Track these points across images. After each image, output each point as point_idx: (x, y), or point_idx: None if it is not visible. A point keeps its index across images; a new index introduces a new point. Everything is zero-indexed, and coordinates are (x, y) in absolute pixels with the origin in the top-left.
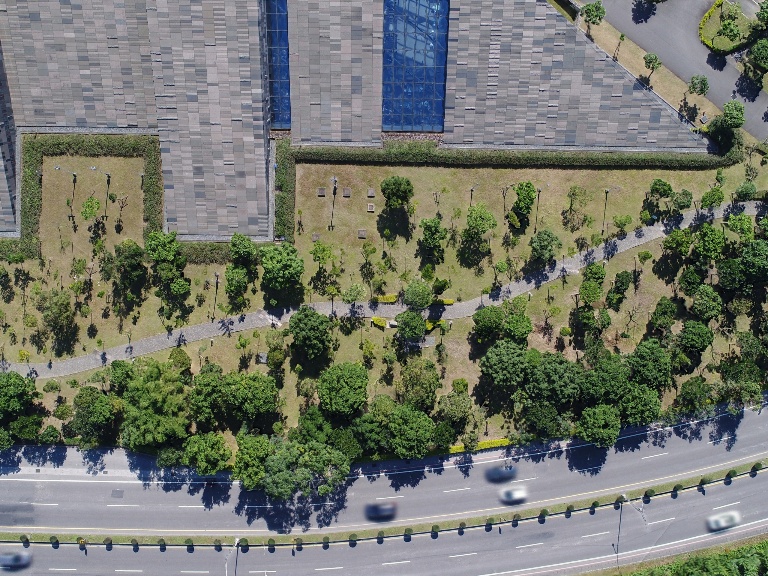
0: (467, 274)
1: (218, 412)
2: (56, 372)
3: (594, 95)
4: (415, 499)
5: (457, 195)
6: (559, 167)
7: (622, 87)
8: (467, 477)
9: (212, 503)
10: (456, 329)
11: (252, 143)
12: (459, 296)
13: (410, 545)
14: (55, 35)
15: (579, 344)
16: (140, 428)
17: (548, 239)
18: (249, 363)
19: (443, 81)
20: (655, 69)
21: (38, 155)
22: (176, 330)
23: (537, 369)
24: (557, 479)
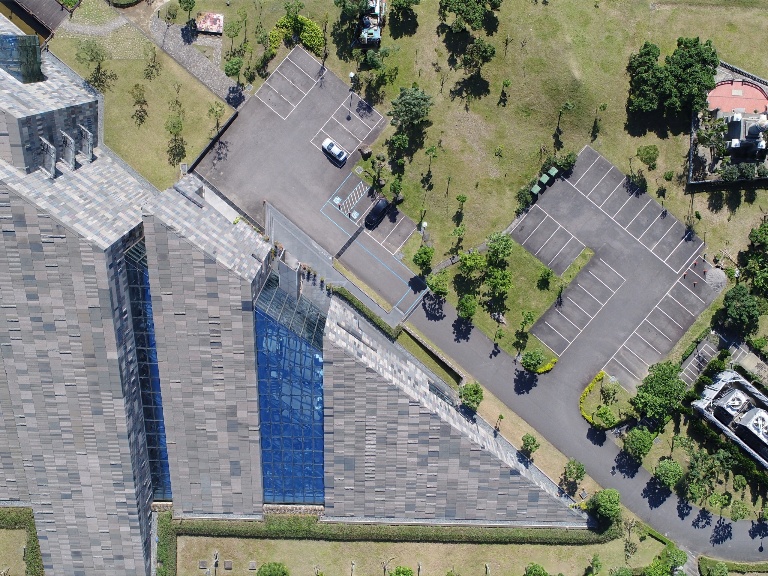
0: None
1: None
2: None
3: (472, 478)
4: None
5: (338, 568)
6: (439, 541)
7: (499, 472)
8: None
9: None
10: None
11: (129, 533)
12: None
13: None
14: None
15: None
16: None
17: None
18: None
19: (322, 462)
20: (533, 452)
21: None
22: None
23: None
24: None
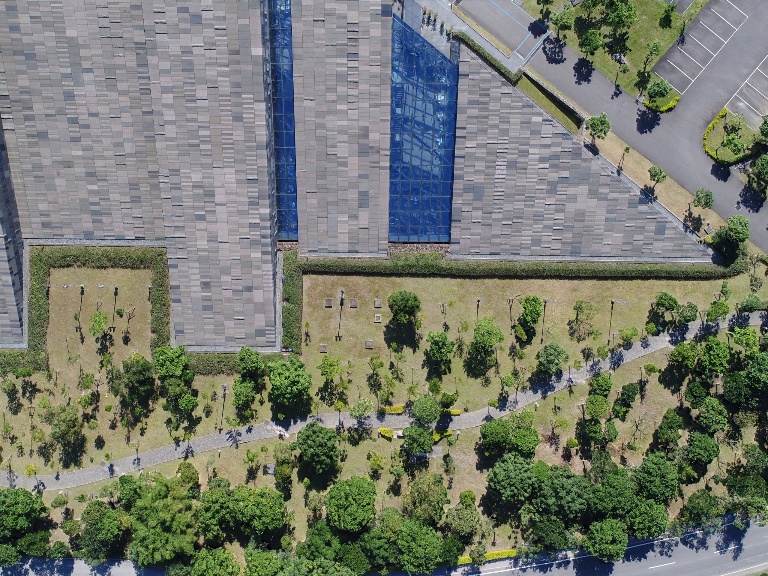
0: (474, 384)
1: (226, 527)
2: (63, 484)
3: (600, 208)
4: None
5: (464, 306)
6: (565, 277)
7: (627, 201)
8: None
9: None
10: (463, 439)
11: (260, 259)
12: (466, 406)
13: None
14: (63, 152)
15: (586, 454)
16: (148, 548)
17: (555, 353)
18: (257, 474)
19: (449, 194)
20: (660, 182)
21: (45, 267)
22: None
23: (544, 484)
24: None
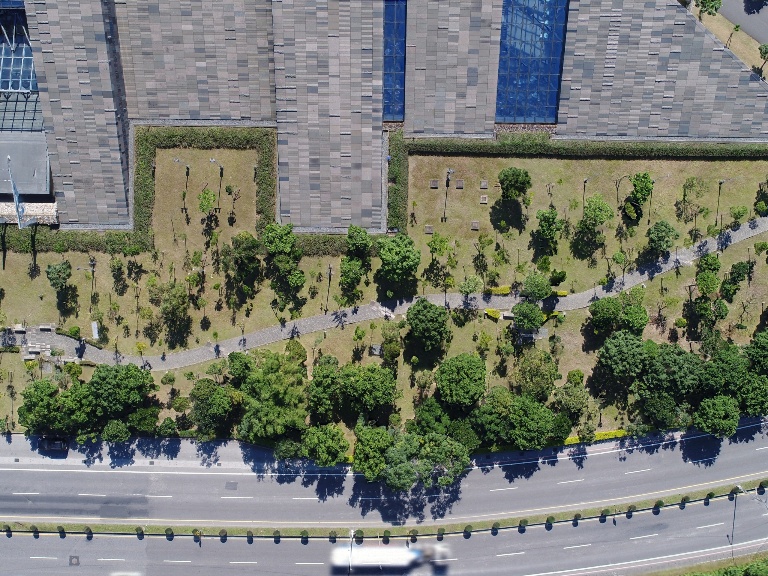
0: (580, 266)
1: (335, 404)
2: (169, 364)
3: (710, 86)
4: (529, 490)
5: (570, 186)
6: (672, 158)
7: (739, 78)
8: (581, 468)
9: (326, 495)
10: (569, 321)
11: (370, 135)
12: (572, 288)
13: (524, 536)
14: (173, 27)
15: (692, 335)
16: (262, 420)
17: (666, 230)
18: (362, 355)
19: (558, 72)
20: None
21: (151, 148)
22: (289, 322)
23: (656, 360)
24: (671, 470)
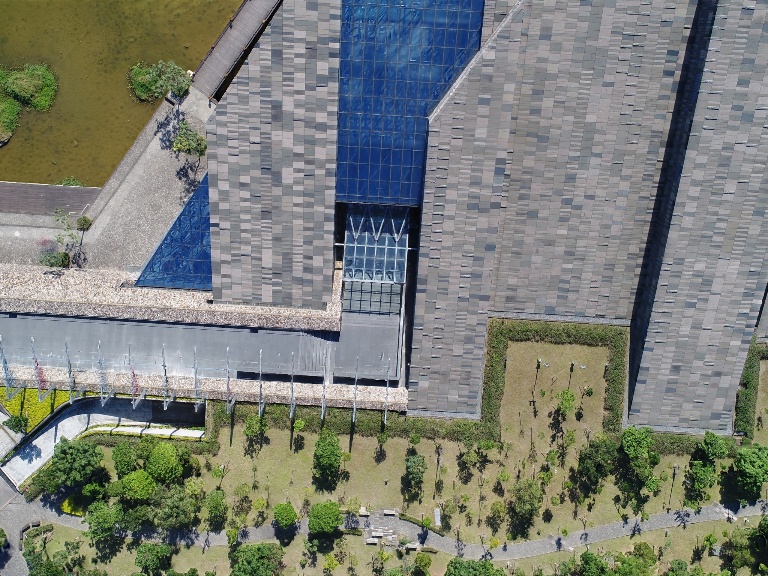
0: None
1: None
2: (510, 555)
3: None
4: None
5: None
6: None
7: None
8: None
9: None
10: None
11: (737, 347)
12: None
13: None
14: (548, 231)
15: None
16: None
17: None
18: (702, 555)
19: None
20: None
21: (505, 341)
22: (631, 519)
23: None
24: None
